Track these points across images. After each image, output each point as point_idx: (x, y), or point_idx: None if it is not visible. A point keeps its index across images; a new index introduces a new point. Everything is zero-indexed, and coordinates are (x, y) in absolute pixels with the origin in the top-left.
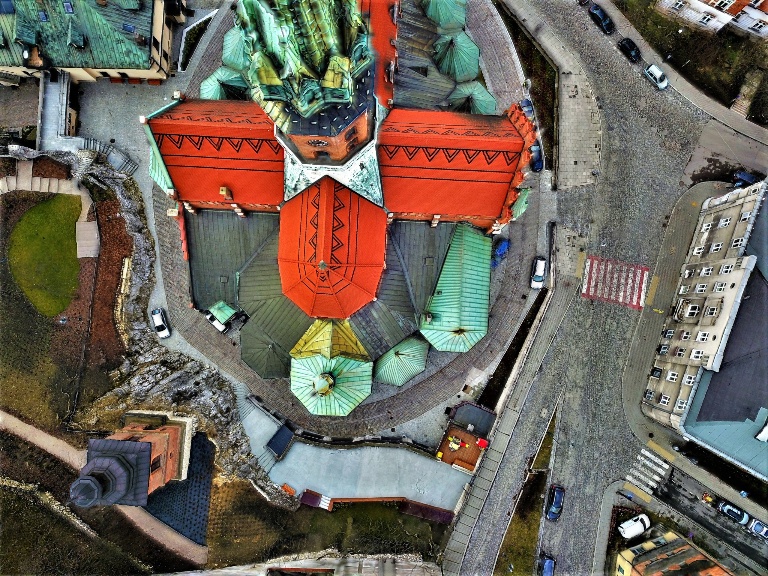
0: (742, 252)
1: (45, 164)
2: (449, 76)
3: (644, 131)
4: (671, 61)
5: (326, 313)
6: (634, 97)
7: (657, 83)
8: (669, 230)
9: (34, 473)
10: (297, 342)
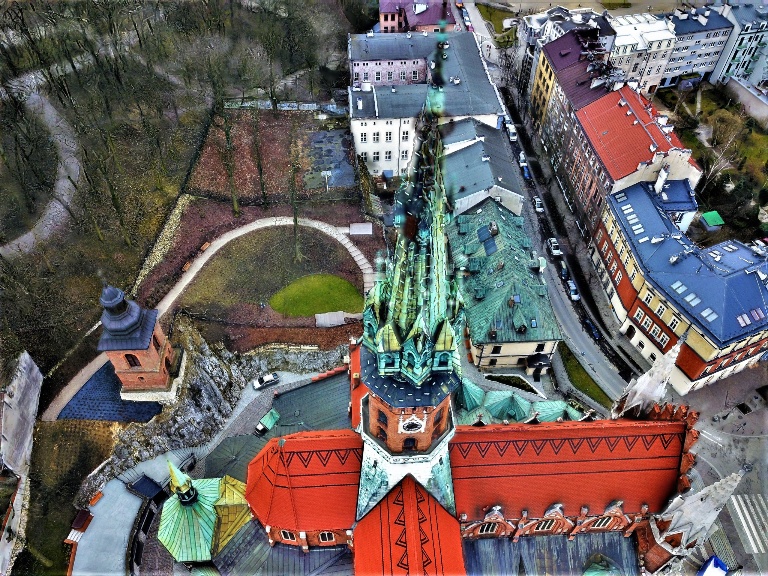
0: None
1: None
2: None
3: None
4: None
5: (250, 477)
6: None
7: None
8: None
9: (144, 293)
10: (235, 478)
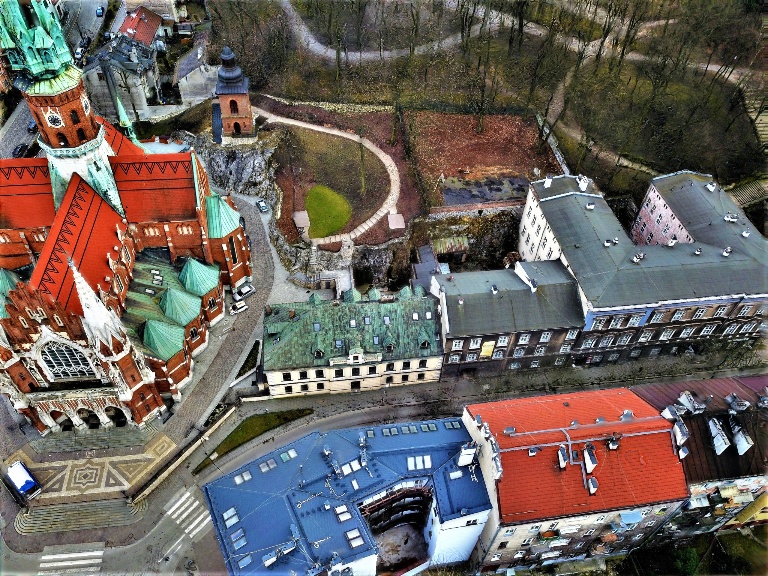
0: None
1: (335, 248)
2: None
3: None
4: None
5: None
6: None
7: None
8: None
9: (297, 109)
10: None
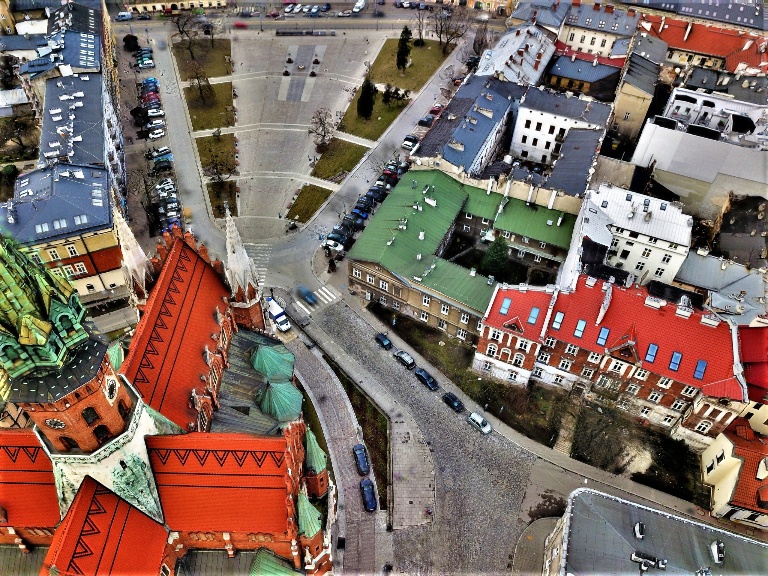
0: (563, 573)
1: None
2: (271, 416)
3: (476, 471)
4: (490, 409)
5: None
6: (463, 441)
7: (481, 428)
8: (515, 571)
9: None
10: None
